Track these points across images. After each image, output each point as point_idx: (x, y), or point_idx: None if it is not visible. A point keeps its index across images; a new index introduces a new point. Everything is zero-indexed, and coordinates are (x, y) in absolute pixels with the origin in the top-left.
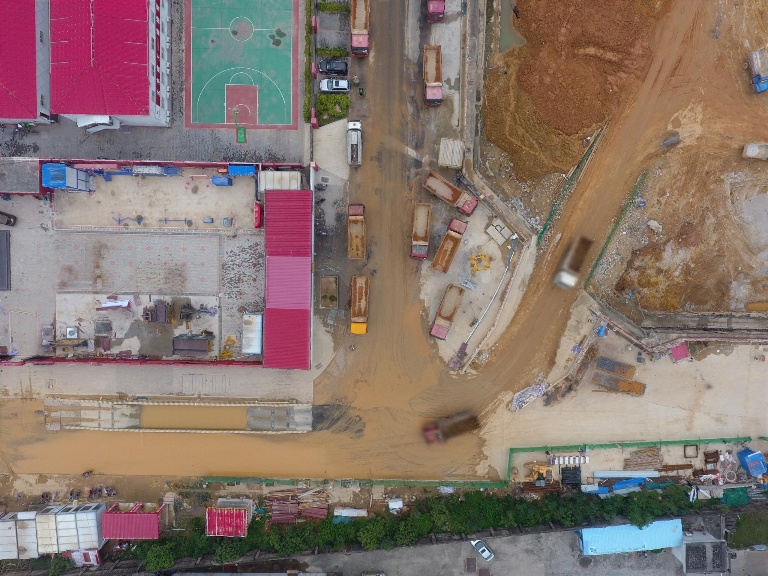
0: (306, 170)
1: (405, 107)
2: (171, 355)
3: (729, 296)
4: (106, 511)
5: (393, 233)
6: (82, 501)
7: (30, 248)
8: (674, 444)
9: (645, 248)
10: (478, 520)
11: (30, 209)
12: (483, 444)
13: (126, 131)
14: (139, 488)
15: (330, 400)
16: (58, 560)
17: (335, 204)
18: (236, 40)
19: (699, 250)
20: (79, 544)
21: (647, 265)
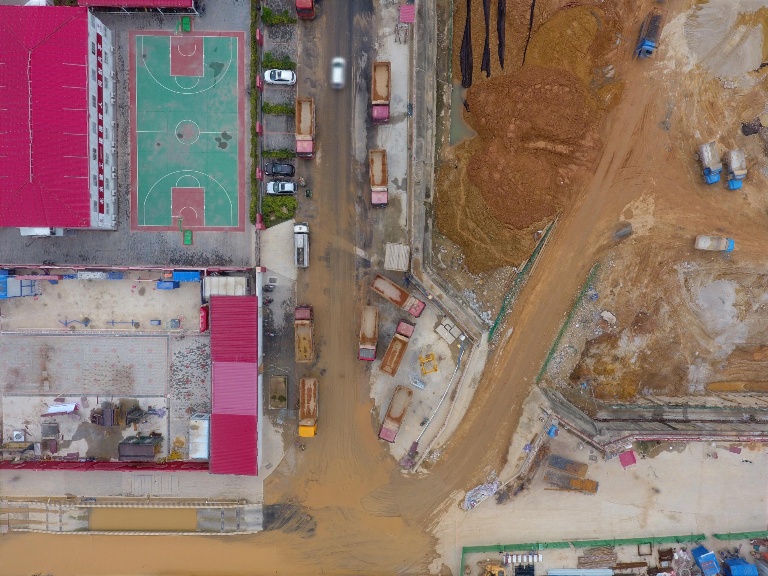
0: (254, 271)
1: (353, 207)
2: None
3: (687, 379)
4: None
5: (342, 332)
6: None
7: None
8: (628, 542)
9: (600, 337)
10: None
11: None
12: (436, 542)
13: (72, 234)
14: None
15: (281, 500)
16: None
17: (283, 304)
18: (182, 143)
19: (655, 337)
20: None
21: (603, 352)
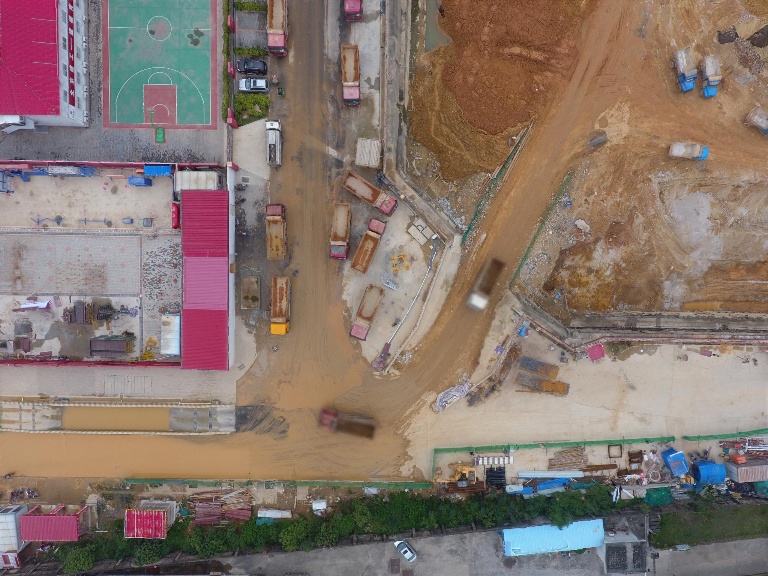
0: None
1: (325, 107)
2: (92, 356)
3: (663, 295)
4: None
5: (315, 233)
6: (4, 503)
7: None
8: (598, 444)
9: (574, 248)
10: (400, 521)
11: None
12: (407, 445)
13: (44, 131)
14: (62, 490)
15: (253, 401)
16: None
17: (256, 204)
18: (154, 40)
19: (630, 249)
20: None
21: (578, 265)
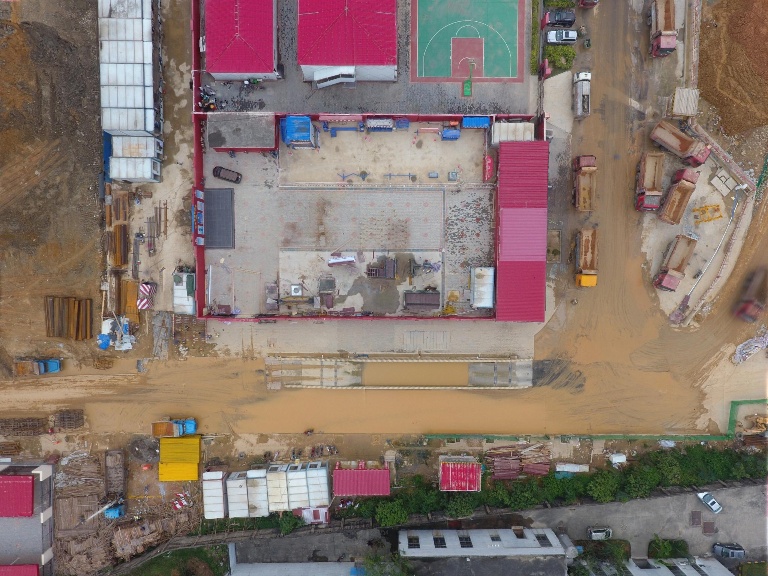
0: None
1: (629, 58)
2: (394, 312)
3: None
4: (329, 469)
5: (615, 186)
6: (304, 460)
7: (254, 206)
8: None
9: None
10: (706, 472)
11: (254, 166)
12: (703, 397)
13: (352, 86)
14: (359, 446)
15: (550, 355)
16: (289, 518)
17: (558, 157)
18: None
19: None
20: (309, 501)
21: None
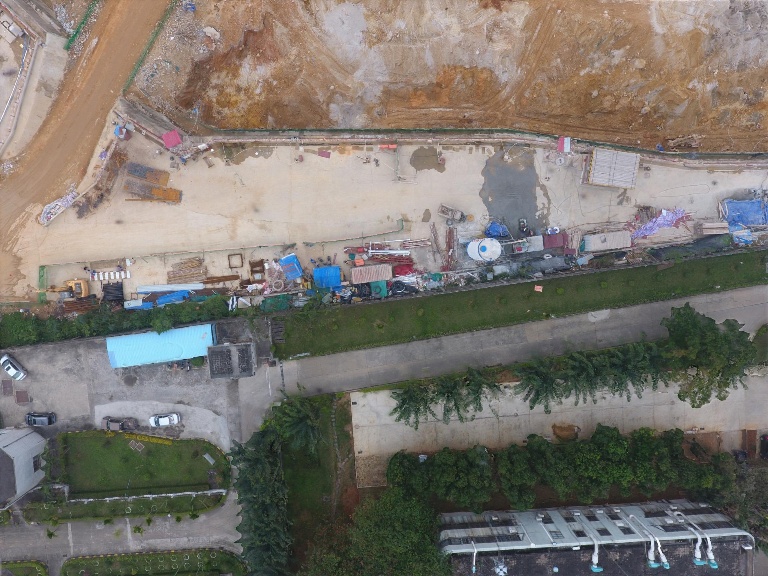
0: None
1: None
2: None
3: (330, 120)
4: None
5: None
6: None
7: None
8: (218, 254)
9: (213, 61)
10: (3, 337)
11: None
12: (19, 262)
13: None
14: None
15: None
16: None
17: None
18: None
19: (279, 65)
20: None
21: (225, 83)
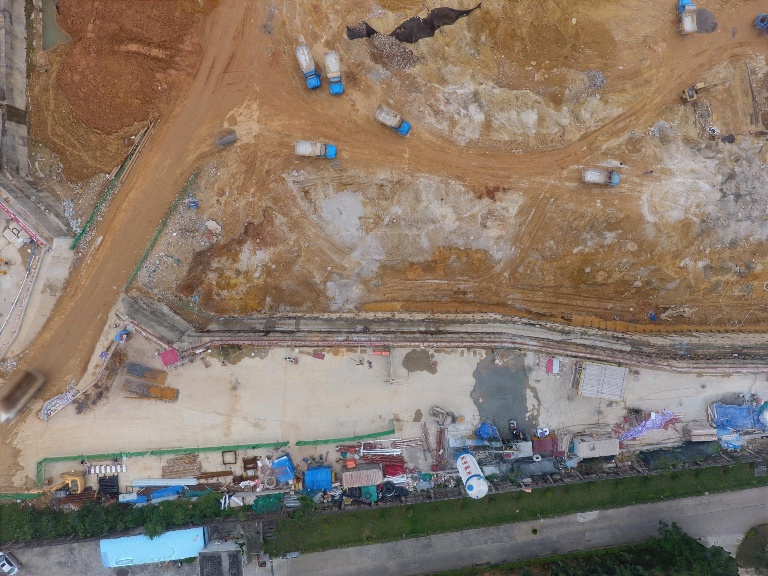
0: None
1: None
2: None
3: (327, 297)
4: None
5: None
6: None
7: None
8: (212, 450)
9: (214, 249)
10: None
11: None
12: (18, 454)
13: None
14: None
15: None
16: None
17: None
18: None
19: (278, 250)
20: None
21: (225, 266)
